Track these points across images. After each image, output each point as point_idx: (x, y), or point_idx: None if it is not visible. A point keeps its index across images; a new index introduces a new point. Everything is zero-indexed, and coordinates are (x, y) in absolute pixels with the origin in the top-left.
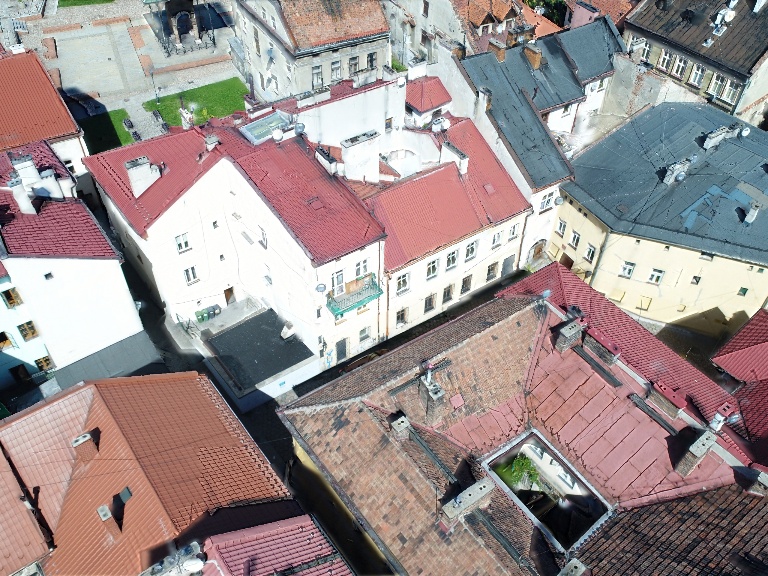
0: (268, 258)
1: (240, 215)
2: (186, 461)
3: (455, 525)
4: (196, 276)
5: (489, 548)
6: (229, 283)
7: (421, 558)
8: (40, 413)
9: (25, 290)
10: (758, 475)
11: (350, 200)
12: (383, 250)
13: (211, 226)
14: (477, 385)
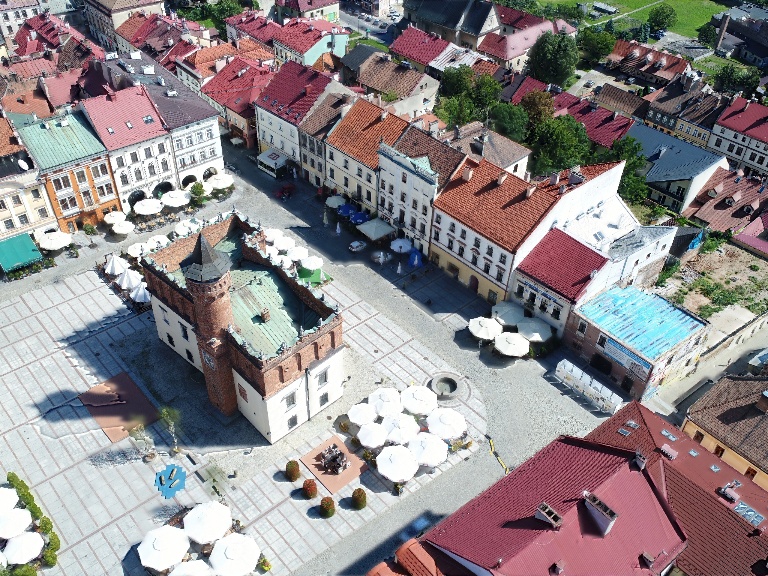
0: None
1: None
2: None
3: None
4: None
5: None
6: None
7: None
8: None
9: None
10: None
11: None
12: None
13: None
14: None
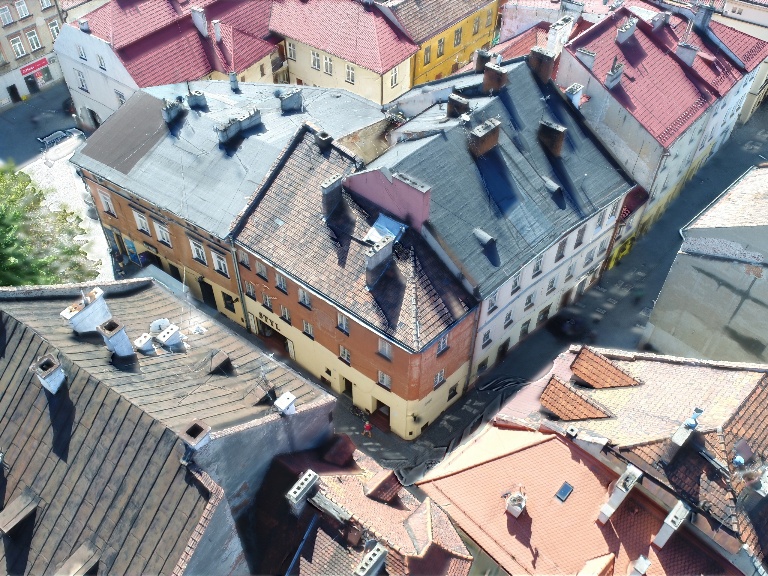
0: None
1: None
2: None
3: None
4: None
5: None
6: None
7: None
8: None
9: None
10: None
11: None
12: None
13: None
14: None
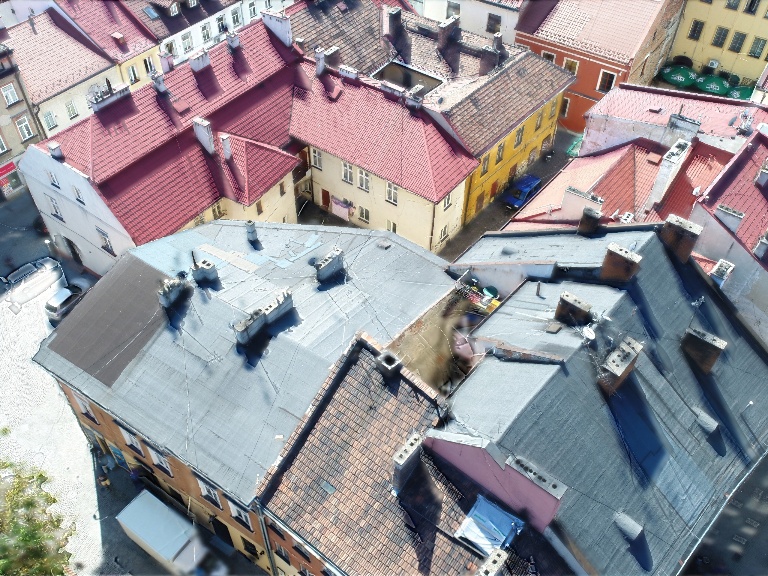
0: None
1: None
2: (590, 7)
3: None
4: None
5: None
6: None
7: None
8: None
9: None
10: None
11: None
12: None
13: None
14: None
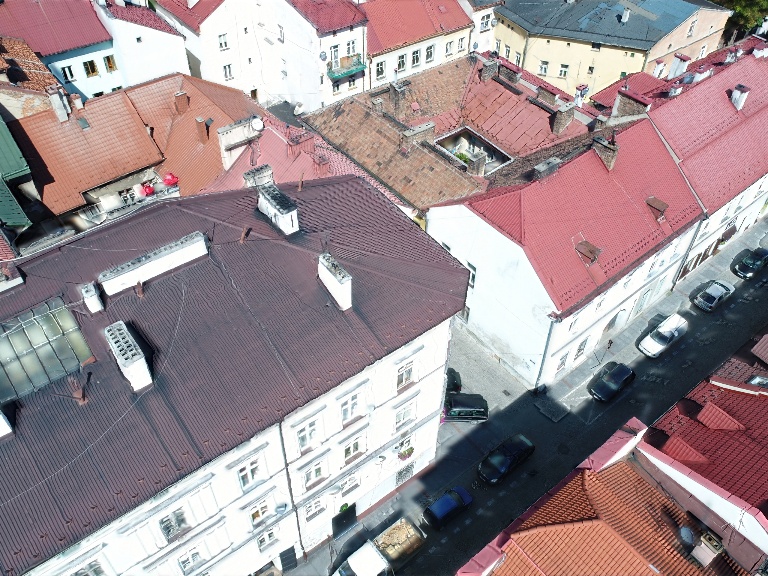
0: (285, 51)
1: (264, 23)
2: None
3: (411, 147)
4: (231, 74)
5: (431, 153)
6: (254, 85)
7: (391, 170)
8: (151, 87)
9: (124, 48)
10: (598, 116)
11: (342, 0)
12: (366, 35)
13: (243, 31)
14: (429, 99)
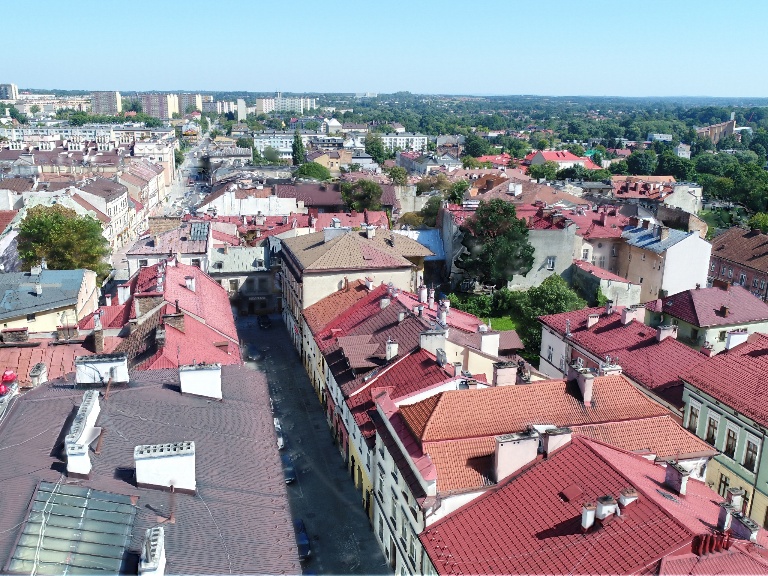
0: None
1: None
2: None
3: None
4: None
5: None
6: None
7: None
8: None
9: None
10: (129, 321)
11: None
12: None
13: None
14: None
